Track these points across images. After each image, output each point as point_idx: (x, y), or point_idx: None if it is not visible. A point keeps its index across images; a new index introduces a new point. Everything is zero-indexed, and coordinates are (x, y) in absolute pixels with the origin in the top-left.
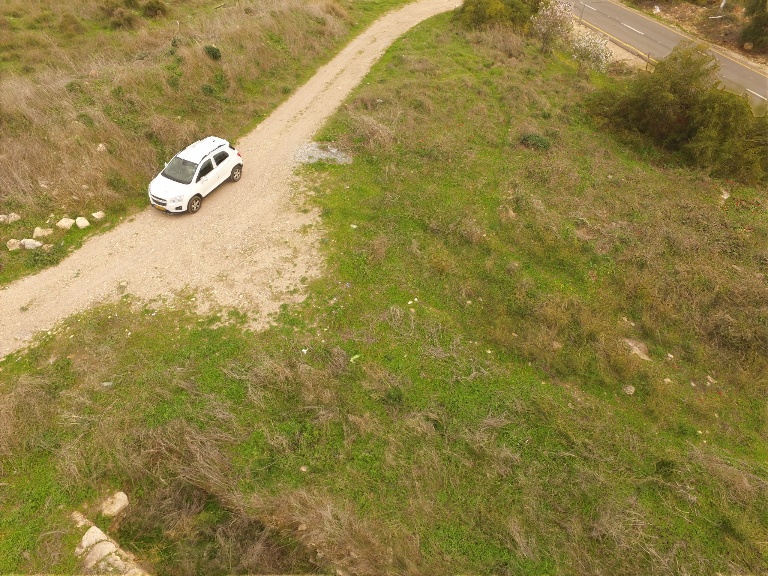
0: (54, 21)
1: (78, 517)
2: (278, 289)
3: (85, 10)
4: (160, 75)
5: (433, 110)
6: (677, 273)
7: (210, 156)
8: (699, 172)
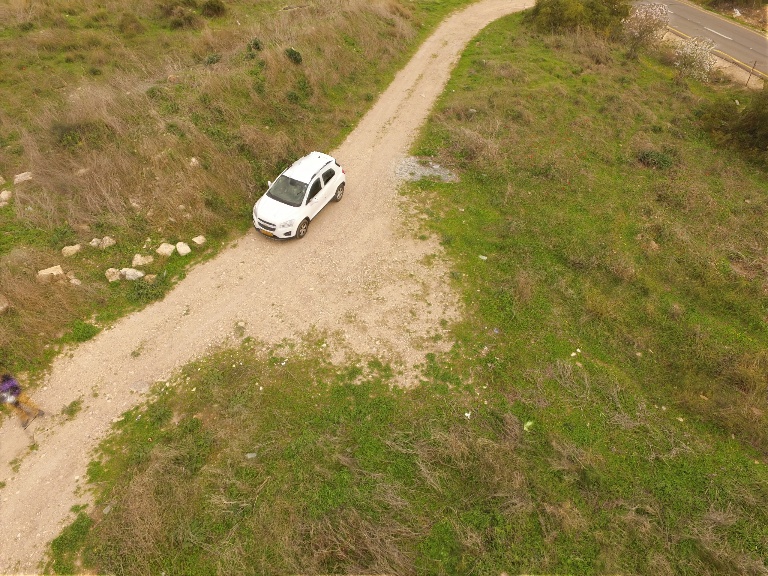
0: (112, 19)
1: None
2: (417, 334)
3: (142, 8)
4: (246, 81)
5: (534, 122)
6: None
7: (319, 175)
8: None
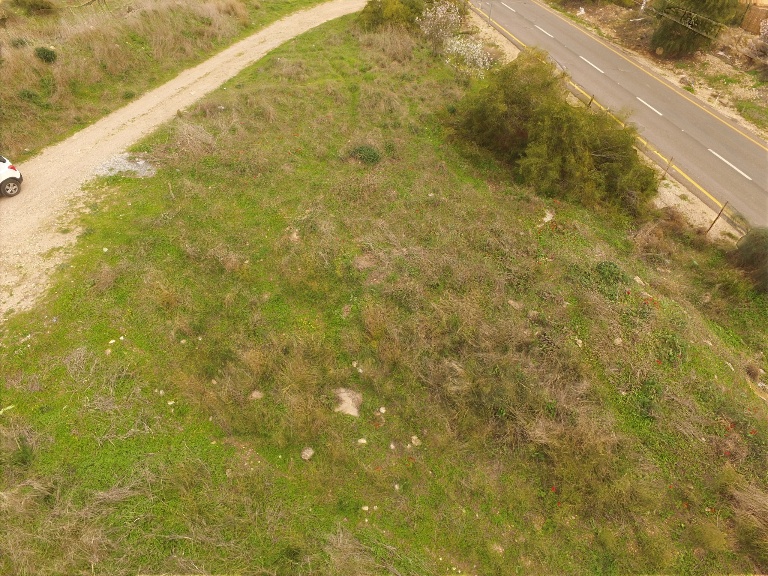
0: None
1: None
2: None
3: None
4: None
5: (272, 118)
6: (433, 310)
7: None
8: (525, 191)
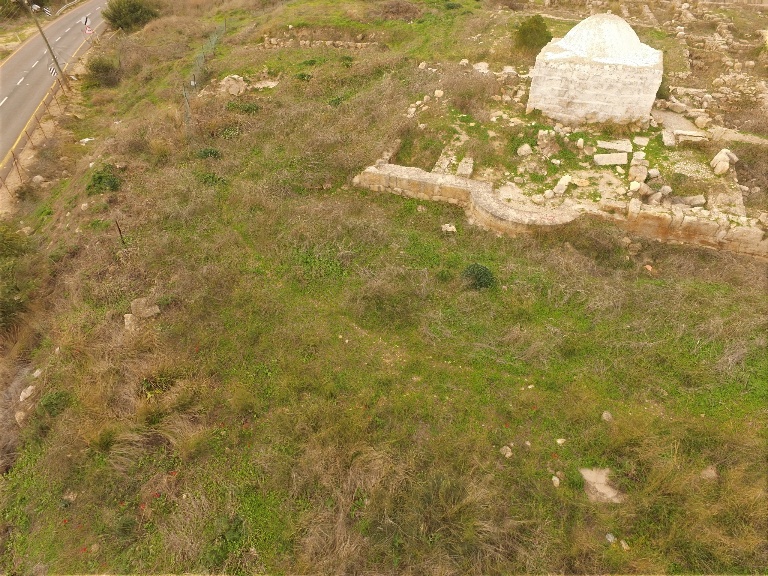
0: None
1: None
2: None
3: None
4: None
5: None
6: None
7: None
8: None
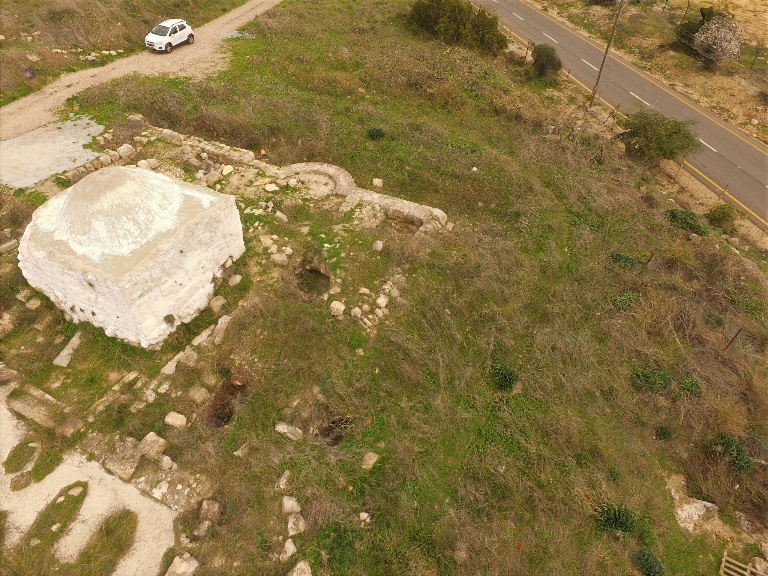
0: None
1: (126, 114)
2: (207, 73)
3: None
4: None
5: (308, 18)
6: None
7: (176, 25)
8: (439, 41)
